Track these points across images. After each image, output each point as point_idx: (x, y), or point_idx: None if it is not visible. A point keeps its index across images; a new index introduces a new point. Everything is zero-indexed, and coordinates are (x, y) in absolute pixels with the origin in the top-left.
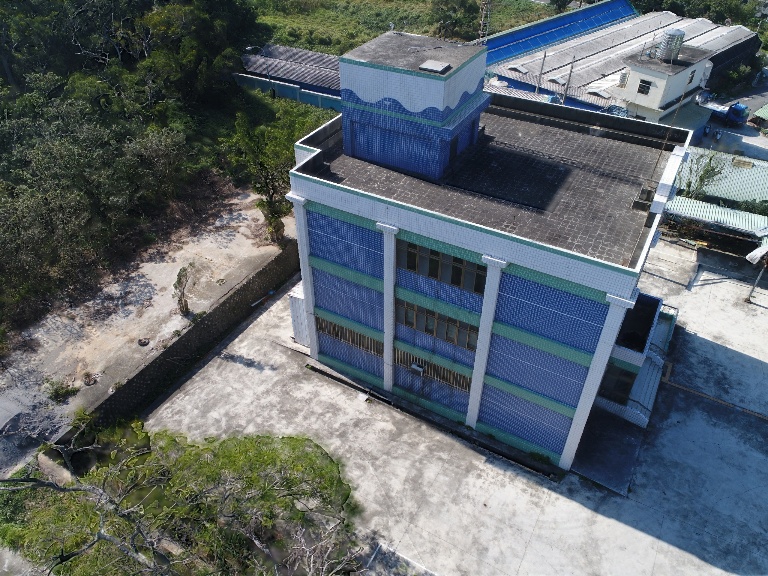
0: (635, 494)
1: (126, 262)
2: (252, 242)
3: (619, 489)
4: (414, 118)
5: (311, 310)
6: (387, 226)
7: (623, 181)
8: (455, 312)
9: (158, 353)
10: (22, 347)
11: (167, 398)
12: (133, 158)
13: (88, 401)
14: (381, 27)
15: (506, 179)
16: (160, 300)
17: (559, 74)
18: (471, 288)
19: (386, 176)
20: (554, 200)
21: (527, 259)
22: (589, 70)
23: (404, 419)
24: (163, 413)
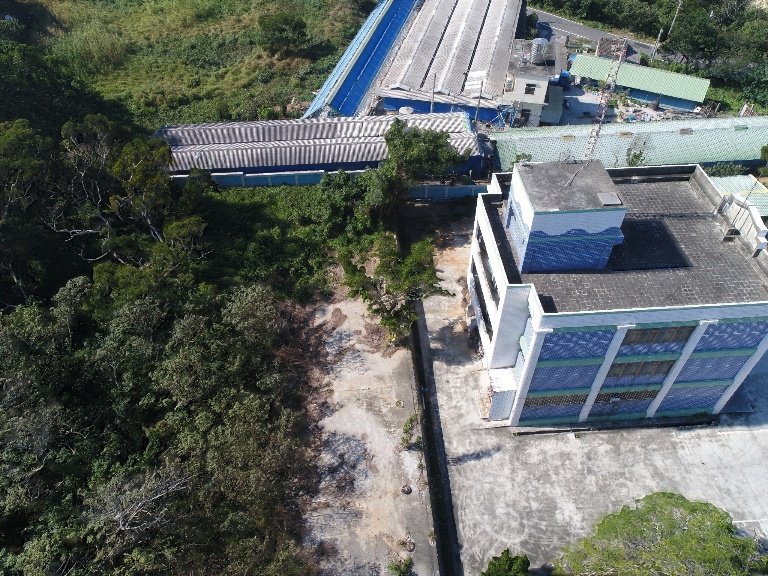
0: (757, 407)
1: (304, 430)
2: (380, 355)
3: (748, 409)
4: (594, 237)
5: (525, 396)
6: (628, 326)
7: (694, 220)
8: (661, 357)
9: (427, 492)
10: (321, 556)
11: (454, 521)
12: (254, 333)
13: (428, 562)
14: (212, 63)
15: (639, 249)
16: (374, 447)
17: (437, 84)
18: (678, 340)
19: (572, 281)
20: (683, 255)
21: (732, 314)
22: (453, 72)
23: (609, 436)
24: (466, 534)
